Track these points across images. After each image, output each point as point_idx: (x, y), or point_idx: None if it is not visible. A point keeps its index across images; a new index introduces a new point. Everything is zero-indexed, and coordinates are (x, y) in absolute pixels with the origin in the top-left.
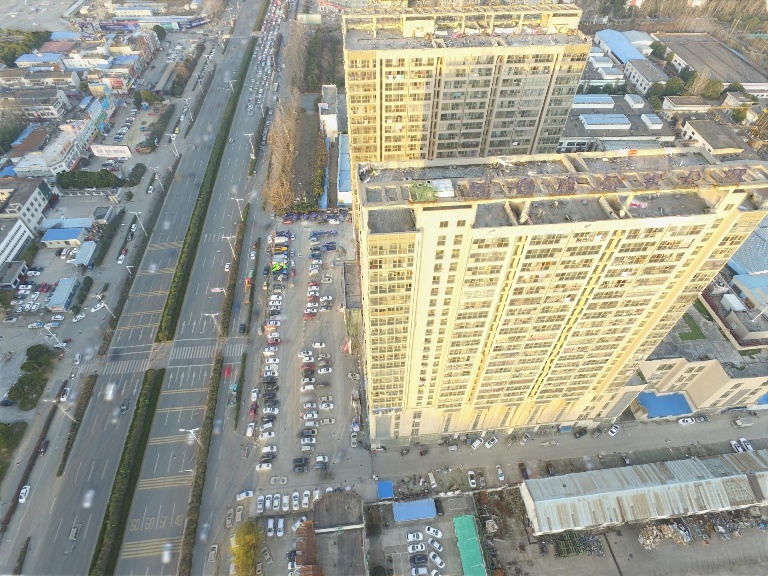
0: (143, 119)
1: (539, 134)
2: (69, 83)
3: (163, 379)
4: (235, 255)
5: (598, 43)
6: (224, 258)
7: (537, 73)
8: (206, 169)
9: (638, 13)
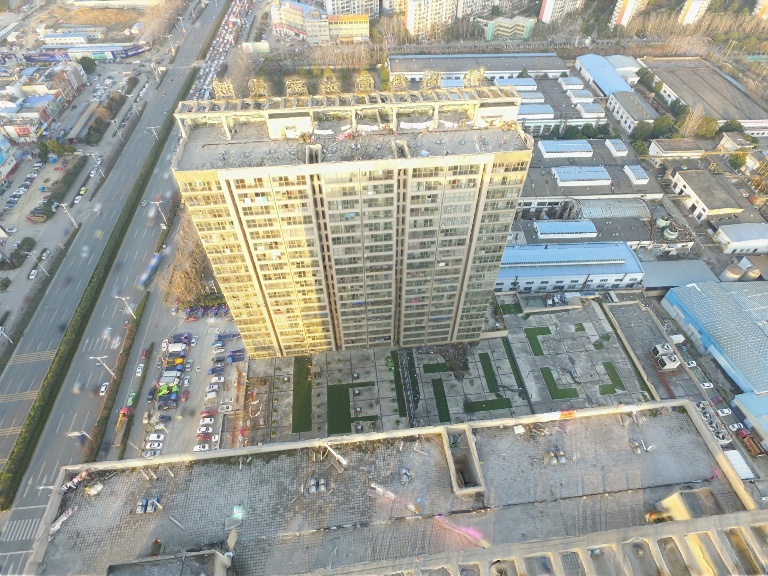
0: (47, 175)
1: (473, 253)
2: None
3: None
4: (114, 373)
5: (579, 69)
6: (103, 375)
7: (459, 187)
8: (106, 244)
9: (624, 33)
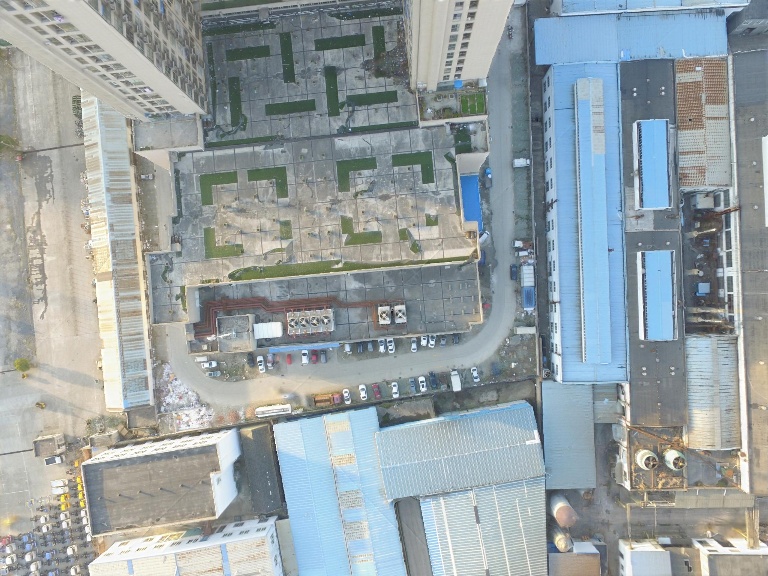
0: None
1: None
2: None
3: None
4: None
5: None
6: None
7: None
8: None
9: None
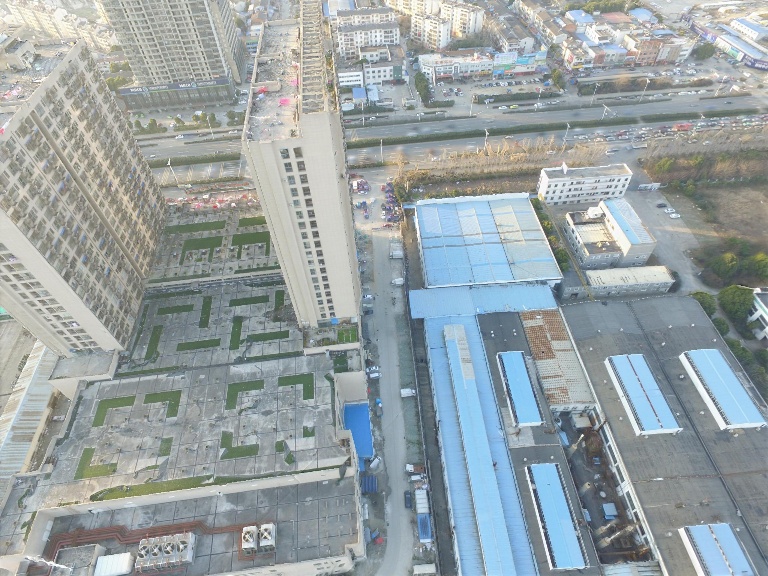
0: (527, 88)
1: None
2: (554, 40)
3: (232, 160)
4: None
5: None
6: None
7: None
8: None
9: None
